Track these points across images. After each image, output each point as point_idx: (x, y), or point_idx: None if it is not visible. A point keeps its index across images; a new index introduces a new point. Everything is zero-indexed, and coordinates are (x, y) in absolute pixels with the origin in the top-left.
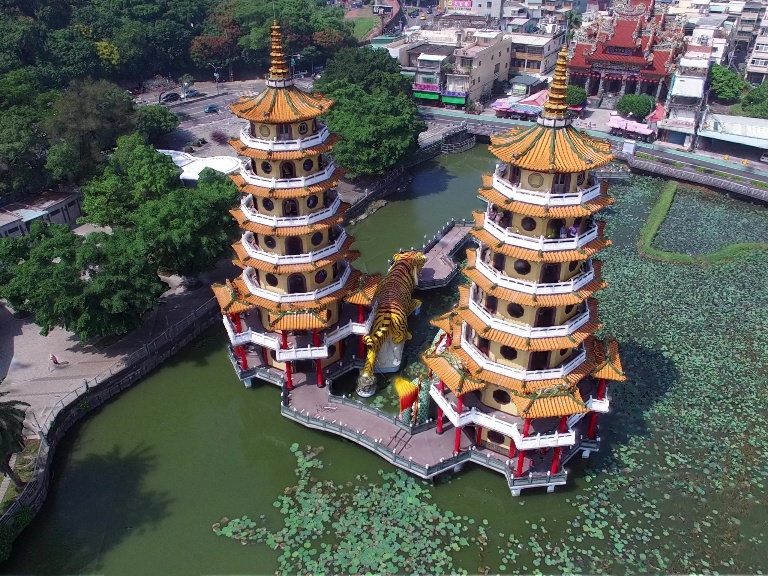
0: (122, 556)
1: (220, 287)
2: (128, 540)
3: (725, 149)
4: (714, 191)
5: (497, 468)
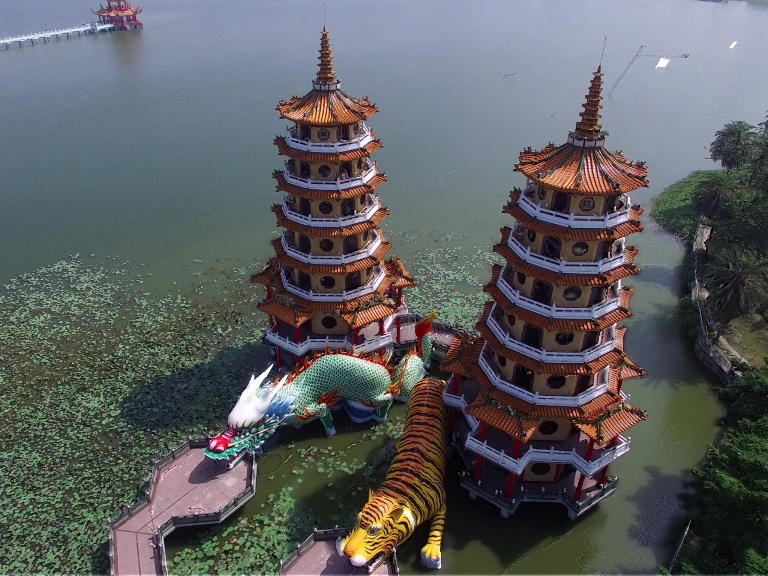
0: None
1: None
2: None
3: None
4: None
5: None
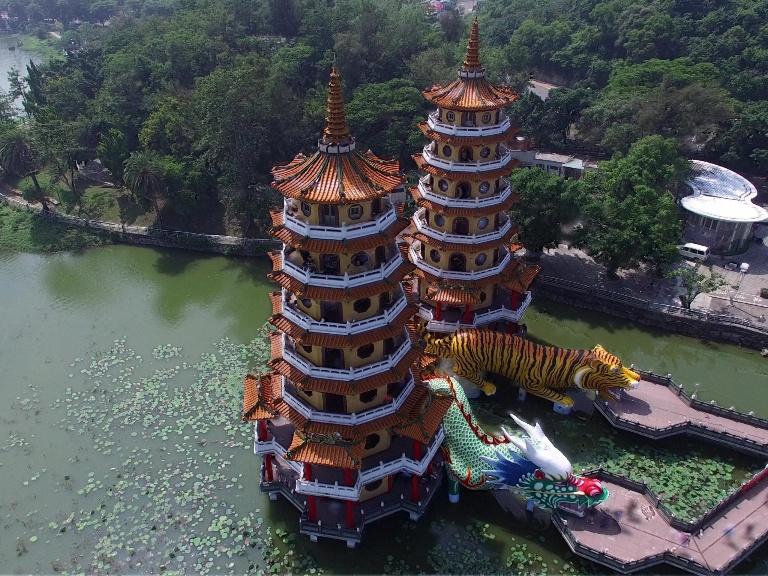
0: (263, 291)
1: None
2: (271, 289)
3: None
4: None
5: None
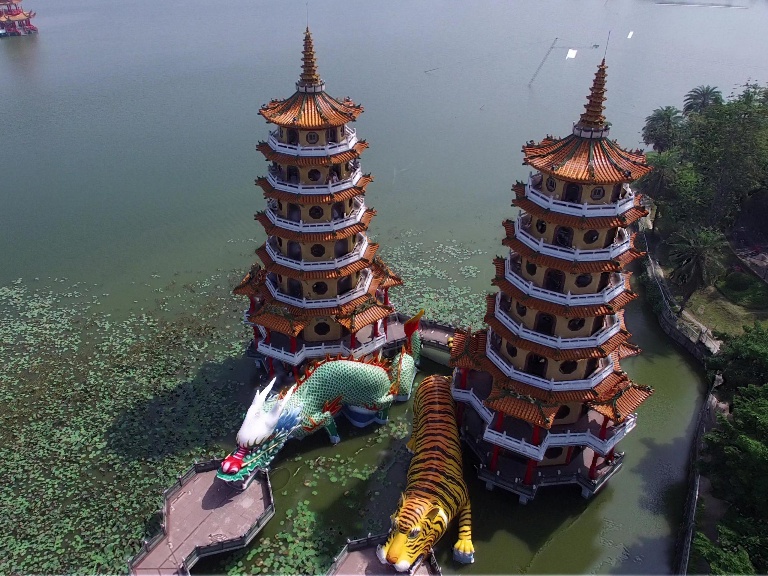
0: None
1: None
2: None
3: None
4: None
5: None
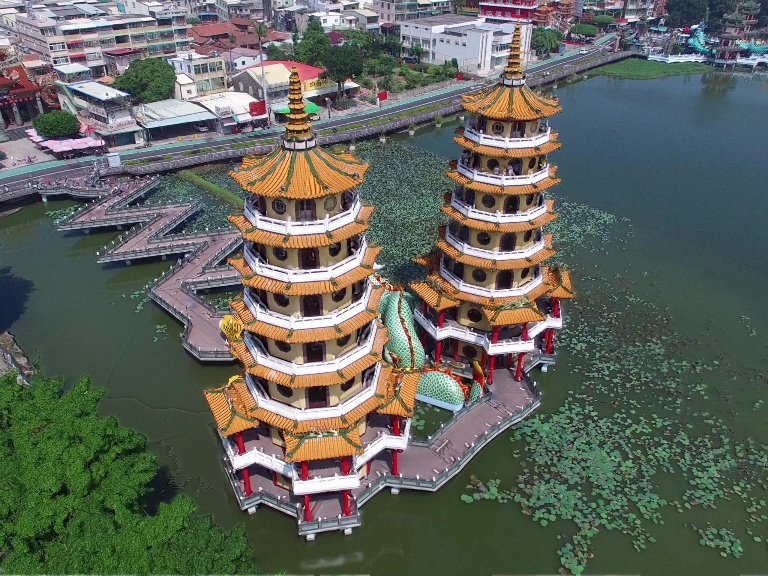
0: None
1: (298, 450)
2: None
3: (174, 132)
4: (217, 164)
5: (536, 363)
